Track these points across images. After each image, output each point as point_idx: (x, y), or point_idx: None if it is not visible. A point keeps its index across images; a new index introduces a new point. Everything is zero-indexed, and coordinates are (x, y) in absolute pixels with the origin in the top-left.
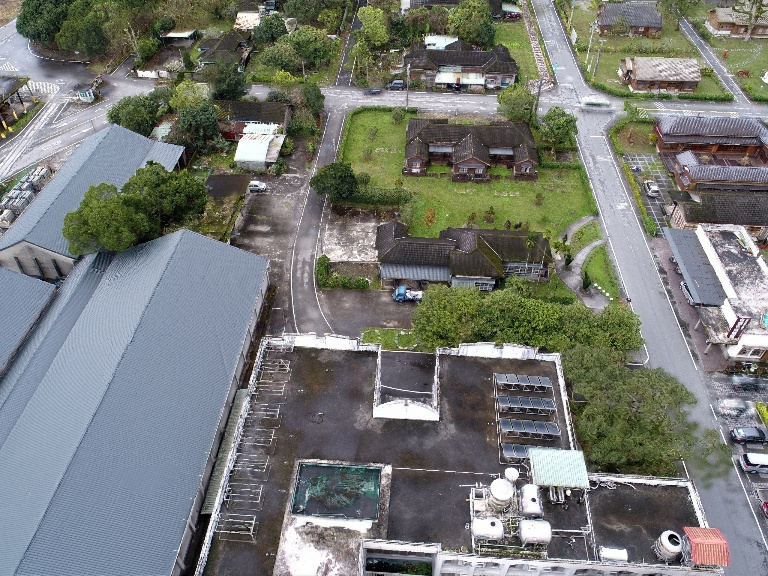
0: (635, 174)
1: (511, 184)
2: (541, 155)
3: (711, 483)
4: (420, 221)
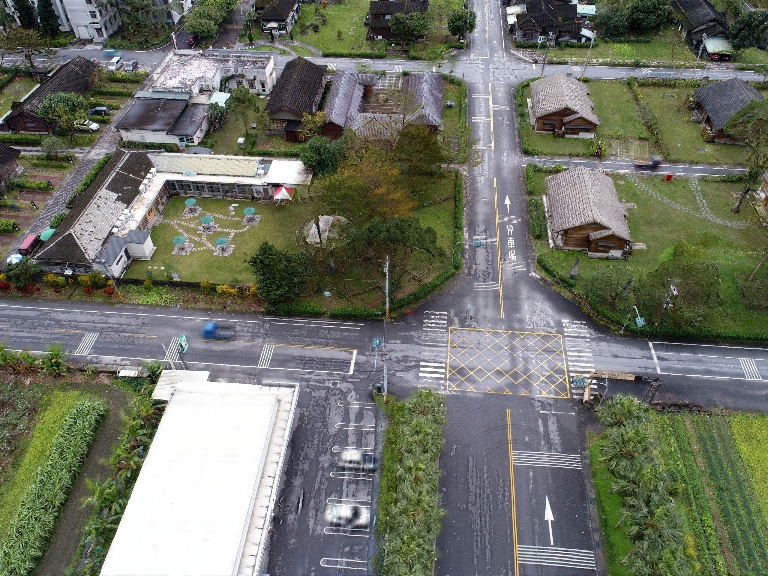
0: (374, 77)
1: (364, 33)
2: (397, 41)
3: (118, 55)
4: (326, 6)
